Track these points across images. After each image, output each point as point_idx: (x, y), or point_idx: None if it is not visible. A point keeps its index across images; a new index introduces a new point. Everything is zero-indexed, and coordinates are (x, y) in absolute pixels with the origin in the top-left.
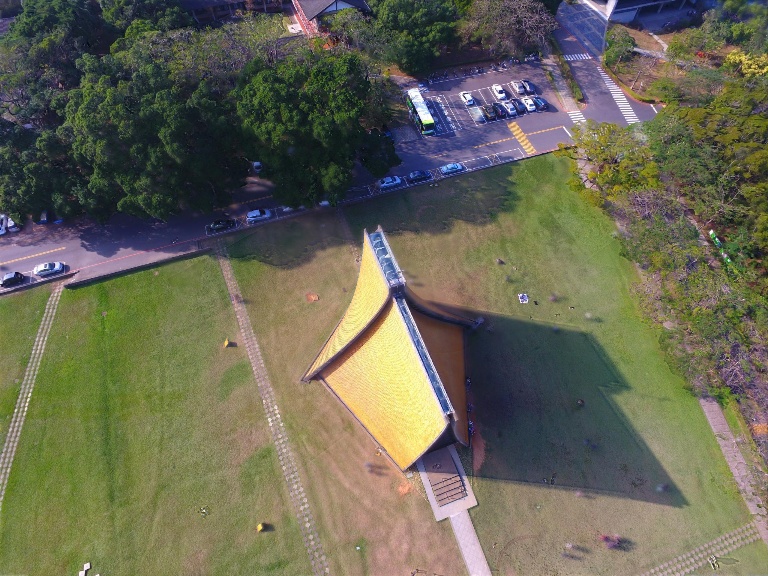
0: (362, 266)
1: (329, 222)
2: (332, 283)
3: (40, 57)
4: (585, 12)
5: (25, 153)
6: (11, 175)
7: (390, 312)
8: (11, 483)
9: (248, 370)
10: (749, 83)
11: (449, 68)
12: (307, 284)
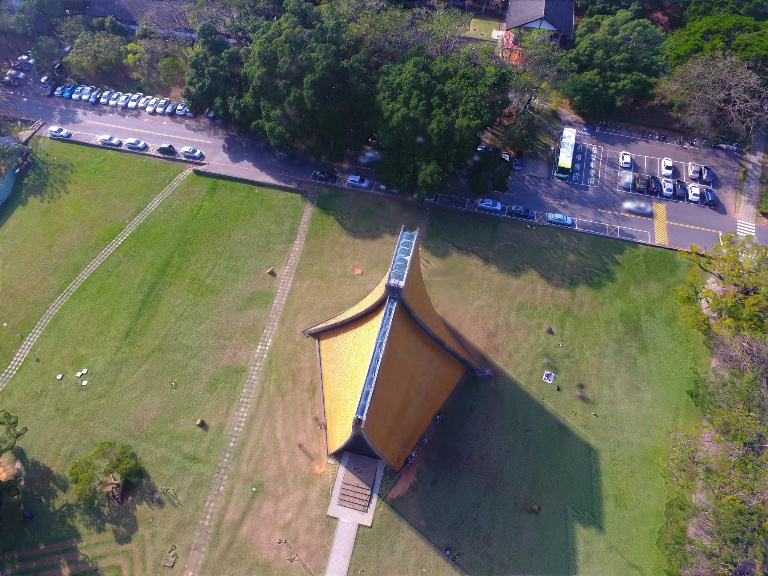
0: None
1: (412, 215)
2: (381, 267)
3: None
4: None
5: (213, 58)
6: (197, 71)
7: (384, 308)
8: (81, 287)
9: (270, 300)
10: None
11: (627, 123)
12: (360, 257)
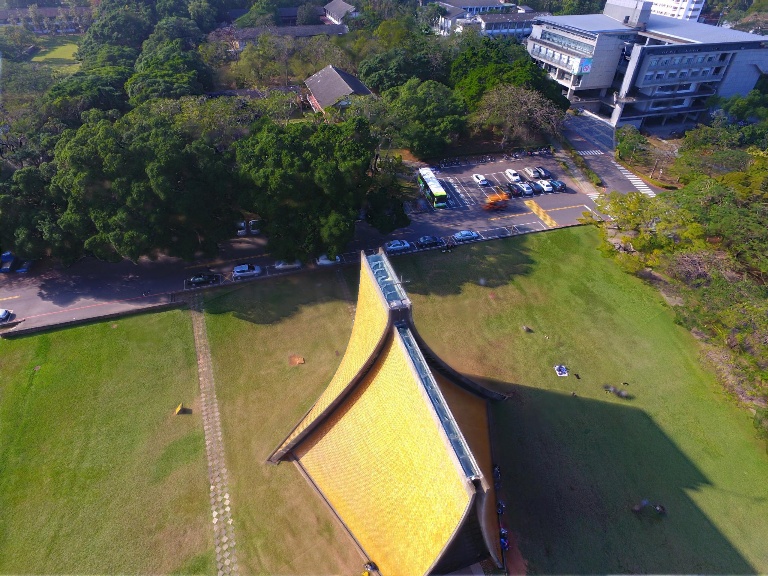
0: (358, 305)
1: (326, 282)
2: (323, 345)
3: (50, 114)
4: (591, 121)
5: None
6: None
7: (390, 351)
8: None
9: (199, 444)
10: None
11: (461, 157)
12: (292, 345)
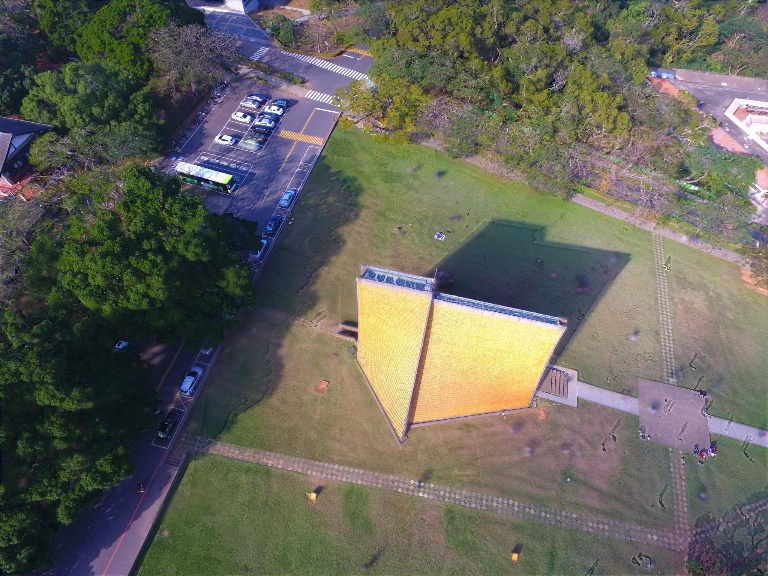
0: (364, 312)
1: (255, 323)
2: (321, 361)
3: None
4: (222, 18)
5: None
6: None
7: (434, 315)
8: None
9: (357, 489)
10: None
11: (178, 128)
12: (305, 383)
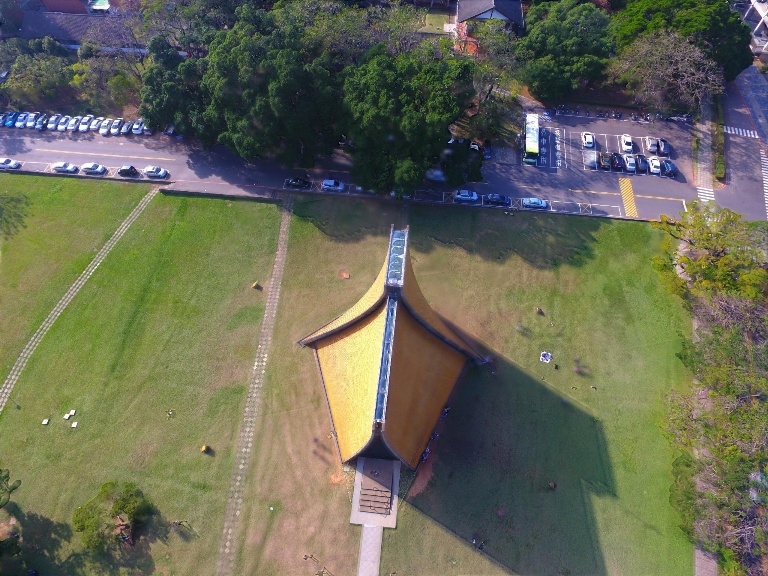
0: None
1: (392, 213)
2: (368, 269)
3: None
4: None
5: (168, 72)
6: (153, 87)
7: (384, 309)
8: (56, 325)
9: (260, 314)
10: None
11: (584, 104)
12: (346, 261)
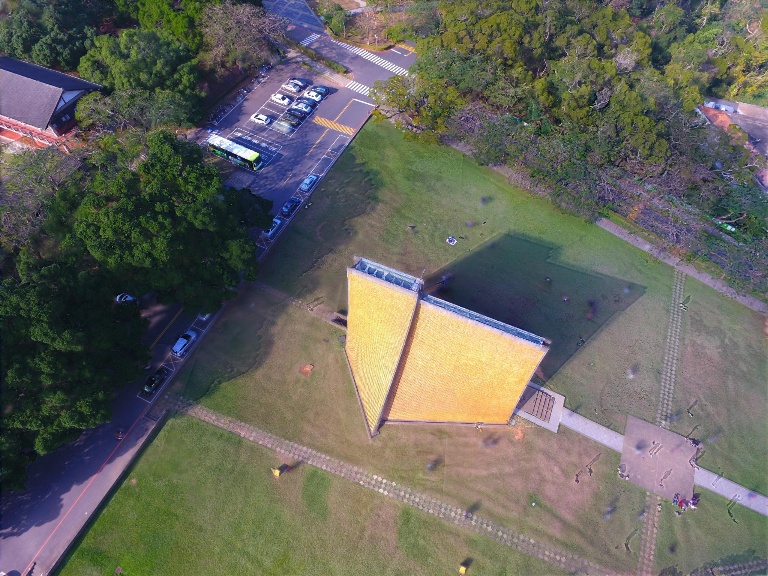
0: (353, 302)
1: (255, 298)
2: (310, 344)
3: None
4: (280, 1)
5: None
6: None
7: (419, 315)
8: None
9: (320, 474)
10: (447, 1)
11: (219, 102)
12: (290, 363)
